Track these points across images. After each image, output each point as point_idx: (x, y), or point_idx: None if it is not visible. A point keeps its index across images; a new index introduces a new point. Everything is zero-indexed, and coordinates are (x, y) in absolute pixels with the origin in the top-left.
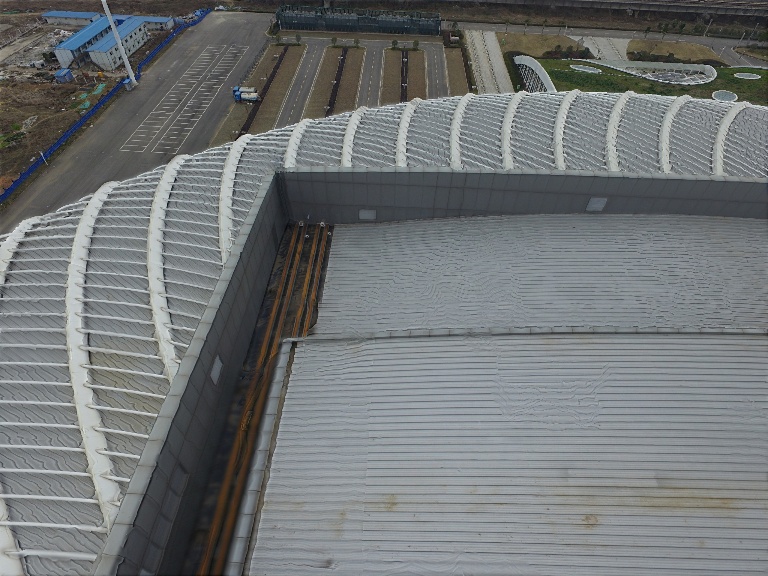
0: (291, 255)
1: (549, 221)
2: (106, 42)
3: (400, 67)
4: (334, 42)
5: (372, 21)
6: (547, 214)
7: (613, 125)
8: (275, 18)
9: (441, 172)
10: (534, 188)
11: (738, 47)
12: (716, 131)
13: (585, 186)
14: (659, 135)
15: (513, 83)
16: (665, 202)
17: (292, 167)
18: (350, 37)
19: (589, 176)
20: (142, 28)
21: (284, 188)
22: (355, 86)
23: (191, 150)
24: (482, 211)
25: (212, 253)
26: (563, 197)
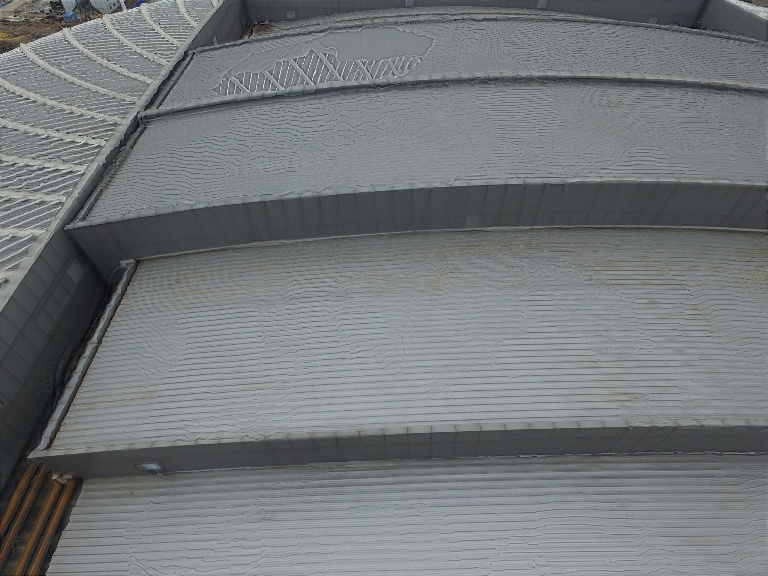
0: (250, 32)
1: (385, 11)
2: None
3: None
4: None
5: None
6: (385, 9)
7: None
8: None
9: None
10: None
11: None
12: None
13: None
14: None
15: None
16: None
17: None
18: None
19: None
20: None
21: None
22: None
23: None
24: (351, 8)
25: (210, 7)
26: None
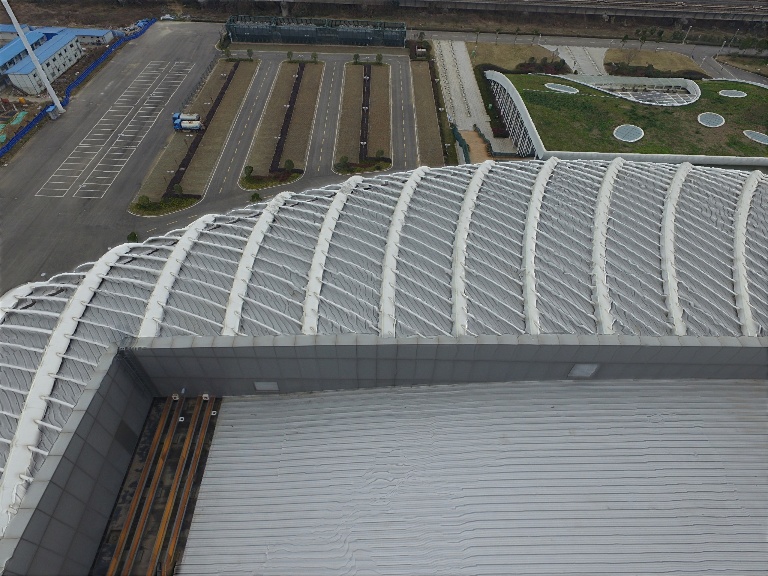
0: (151, 461)
1: (518, 395)
2: (29, 62)
3: (362, 85)
4: (290, 57)
5: (332, 31)
6: (515, 381)
7: (600, 231)
8: (225, 29)
9: (361, 344)
10: (495, 357)
11: (718, 55)
12: (732, 236)
13: (566, 355)
14: (660, 247)
15: (484, 102)
16: (677, 368)
17: (144, 339)
18: (308, 50)
19: (572, 345)
20: (74, 44)
21: (137, 365)
22: (311, 109)
23: (120, 193)
24: (425, 380)
25: None
26: (536, 365)
